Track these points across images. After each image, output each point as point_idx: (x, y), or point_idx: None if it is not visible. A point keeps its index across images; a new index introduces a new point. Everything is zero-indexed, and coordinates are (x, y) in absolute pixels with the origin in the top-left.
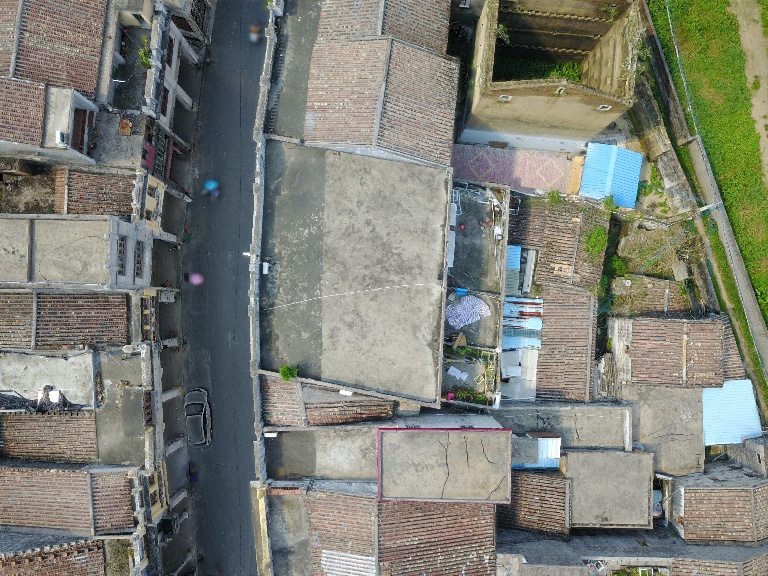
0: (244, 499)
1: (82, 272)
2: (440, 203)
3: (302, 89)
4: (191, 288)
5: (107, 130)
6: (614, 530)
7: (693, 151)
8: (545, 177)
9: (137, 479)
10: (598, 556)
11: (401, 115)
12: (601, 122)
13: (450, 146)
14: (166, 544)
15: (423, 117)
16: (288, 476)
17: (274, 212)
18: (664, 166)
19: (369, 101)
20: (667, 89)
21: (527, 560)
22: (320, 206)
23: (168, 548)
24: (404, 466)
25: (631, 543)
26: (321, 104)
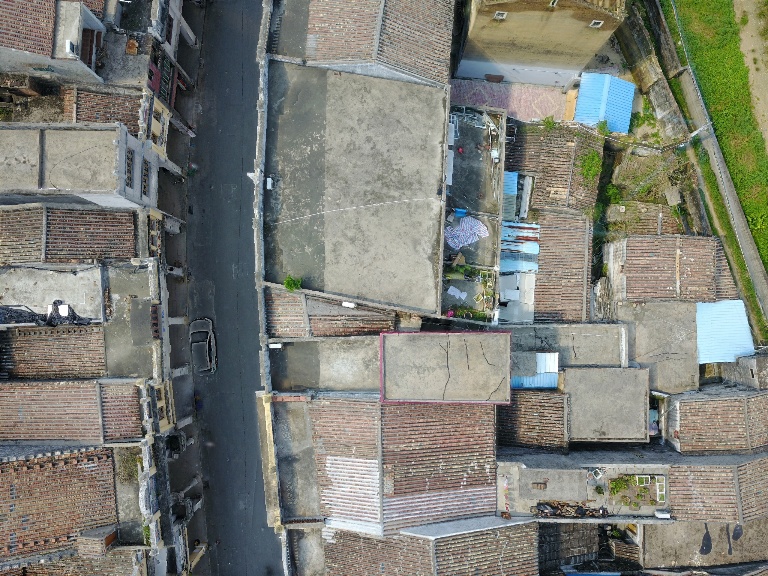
0: (249, 426)
1: (91, 181)
2: (438, 121)
3: (303, 12)
4: (195, 221)
5: (114, 50)
6: (612, 447)
7: (684, 82)
8: (540, 110)
9: (145, 389)
10: (596, 463)
11: (400, 32)
12: (594, 43)
13: (448, 65)
14: (173, 460)
15: (421, 36)
16: (293, 388)
17: (277, 130)
18: (656, 96)
19: (369, 18)
20: (658, 22)
21: (527, 466)
22: (322, 124)
23: (174, 475)
24: (406, 369)
25: (628, 455)
26: (322, 25)
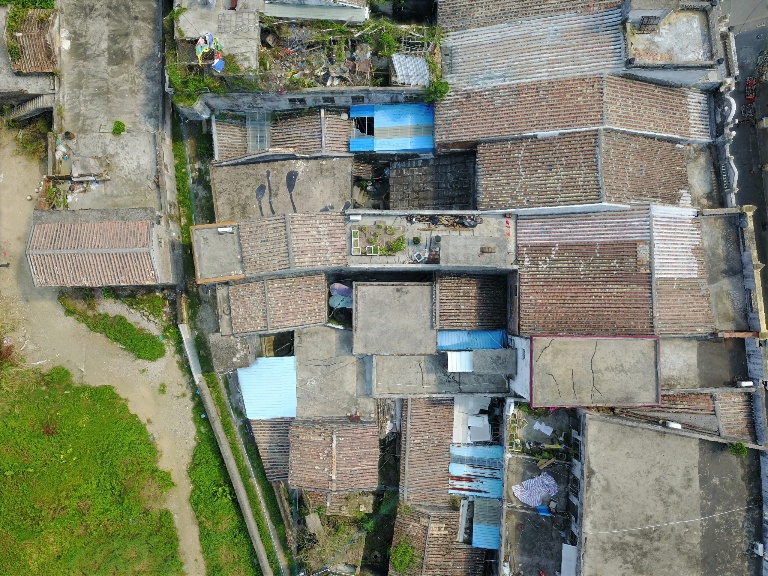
0: None
1: None
2: None
3: None
4: None
5: None
6: (381, 273)
7: None
8: None
9: None
10: None
11: None
12: None
13: None
14: None
15: None
16: (724, 340)
17: None
18: None
19: None
20: None
21: None
22: None
23: None
24: (634, 370)
25: None
26: None
